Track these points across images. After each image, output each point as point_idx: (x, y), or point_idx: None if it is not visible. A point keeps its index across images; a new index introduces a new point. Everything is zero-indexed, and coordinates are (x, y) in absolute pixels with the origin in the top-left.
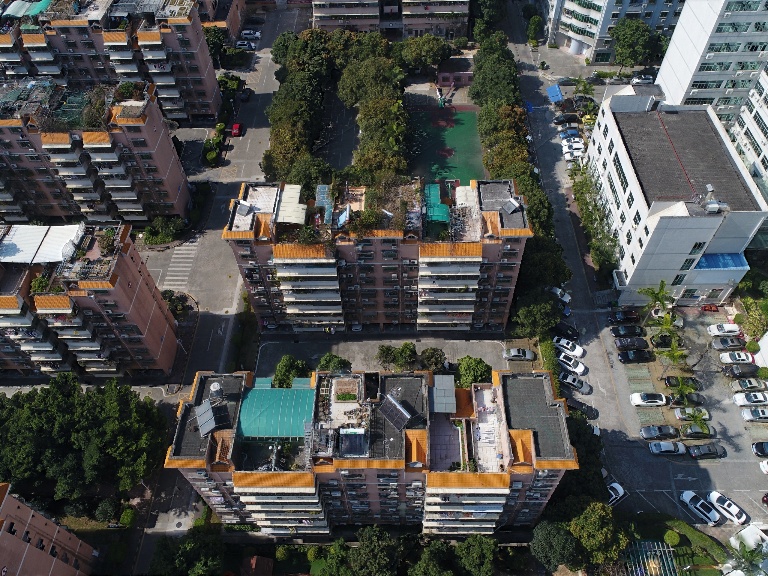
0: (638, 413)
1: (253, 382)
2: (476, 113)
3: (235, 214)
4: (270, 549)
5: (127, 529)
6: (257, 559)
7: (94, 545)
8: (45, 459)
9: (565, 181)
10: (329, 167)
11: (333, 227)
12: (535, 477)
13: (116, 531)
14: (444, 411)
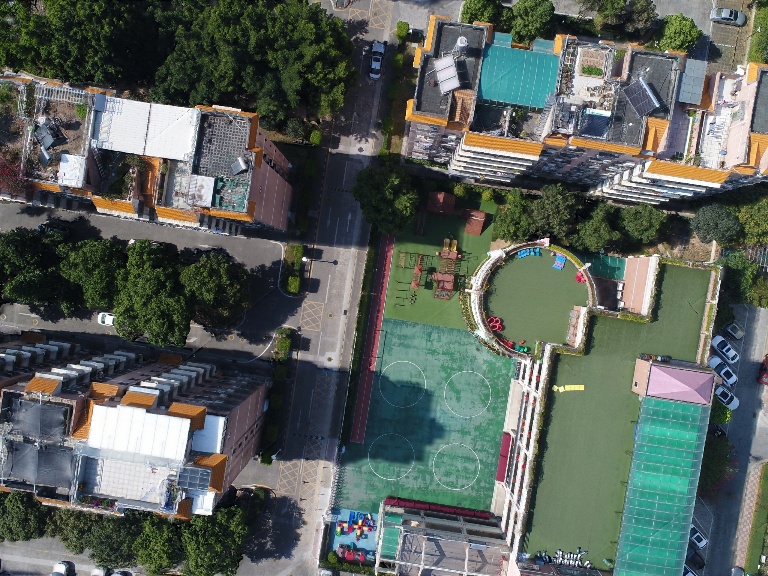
0: None
1: (492, 37)
2: None
3: None
4: (449, 185)
5: (314, 147)
6: (444, 195)
7: (285, 157)
8: (248, 77)
9: None
10: None
11: None
12: (748, 176)
13: (303, 147)
14: (689, 101)
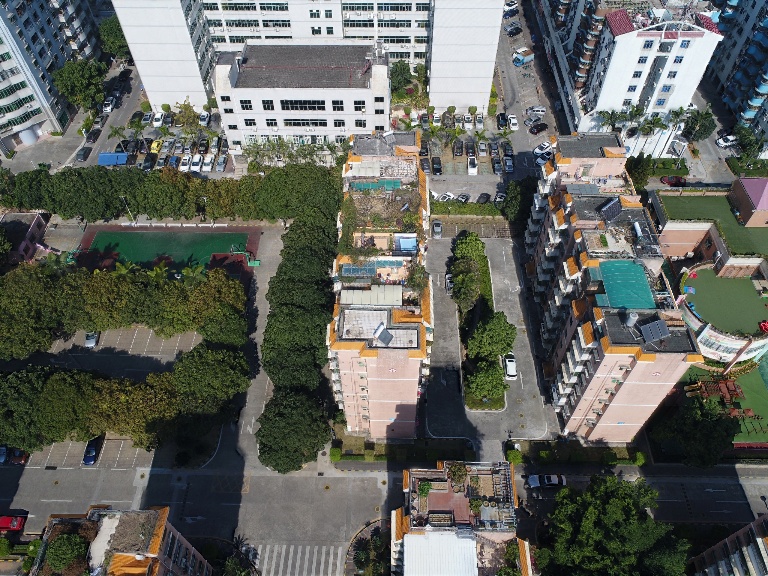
0: (482, 174)
1: None
2: (102, 231)
3: (389, 347)
4: None
5: None
6: None
7: None
8: None
9: (238, 177)
10: (200, 346)
11: (414, 255)
12: None
13: None
14: None
